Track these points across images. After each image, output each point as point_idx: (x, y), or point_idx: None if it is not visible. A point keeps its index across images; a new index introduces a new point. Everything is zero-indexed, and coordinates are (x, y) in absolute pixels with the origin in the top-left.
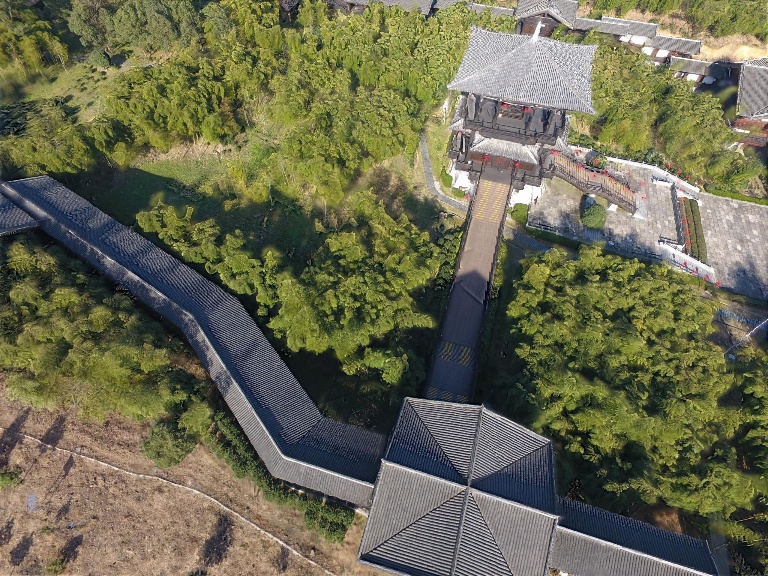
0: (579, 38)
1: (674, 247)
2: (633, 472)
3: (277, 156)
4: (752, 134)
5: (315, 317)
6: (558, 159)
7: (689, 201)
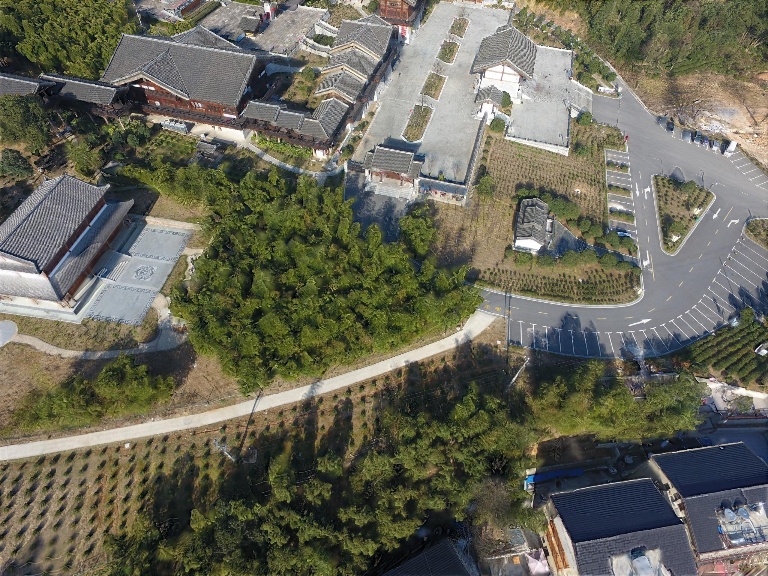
0: None
1: None
2: None
3: None
4: None
5: None
6: None
7: None
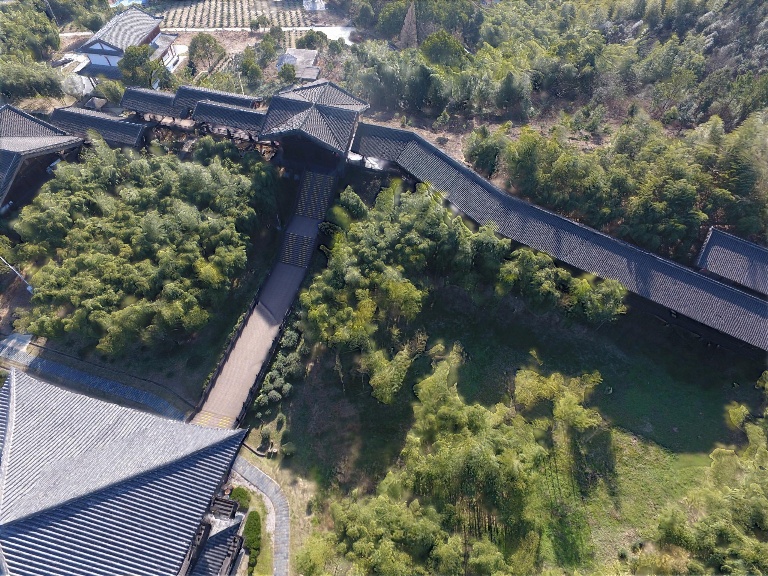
0: None
1: None
2: (207, 155)
3: None
4: None
5: (414, 211)
6: None
7: None
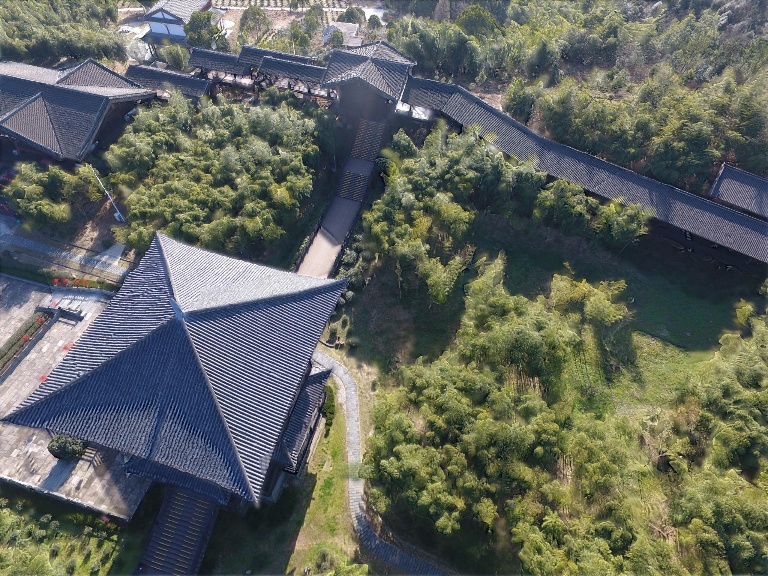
0: None
1: None
2: (272, 103)
3: (562, 324)
4: None
5: (460, 149)
6: None
7: None
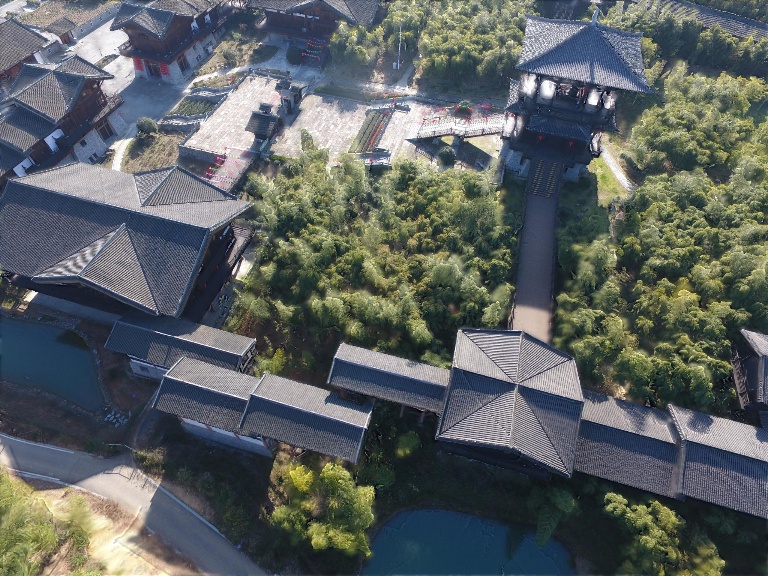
0: (431, 356)
1: None
2: None
3: None
4: None
5: None
6: (499, 126)
7: None
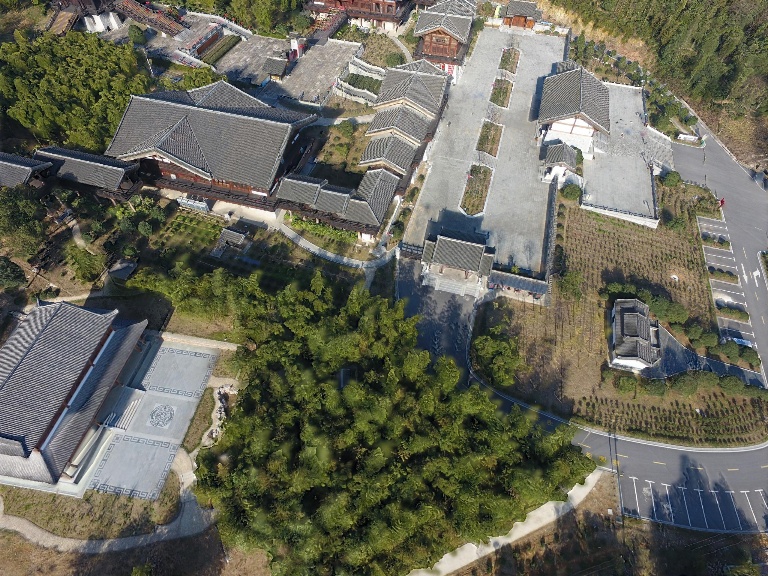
0: None
1: (184, 52)
2: None
3: None
4: (326, 5)
5: None
6: (126, 3)
7: (233, 36)
